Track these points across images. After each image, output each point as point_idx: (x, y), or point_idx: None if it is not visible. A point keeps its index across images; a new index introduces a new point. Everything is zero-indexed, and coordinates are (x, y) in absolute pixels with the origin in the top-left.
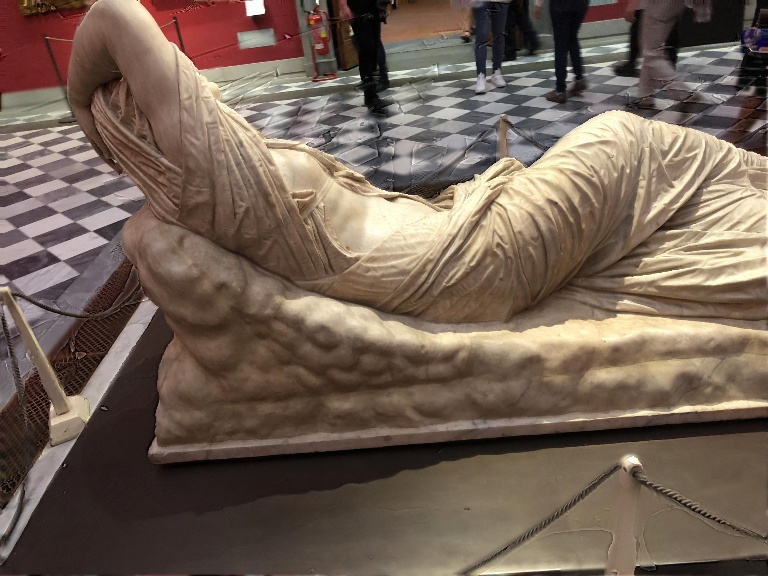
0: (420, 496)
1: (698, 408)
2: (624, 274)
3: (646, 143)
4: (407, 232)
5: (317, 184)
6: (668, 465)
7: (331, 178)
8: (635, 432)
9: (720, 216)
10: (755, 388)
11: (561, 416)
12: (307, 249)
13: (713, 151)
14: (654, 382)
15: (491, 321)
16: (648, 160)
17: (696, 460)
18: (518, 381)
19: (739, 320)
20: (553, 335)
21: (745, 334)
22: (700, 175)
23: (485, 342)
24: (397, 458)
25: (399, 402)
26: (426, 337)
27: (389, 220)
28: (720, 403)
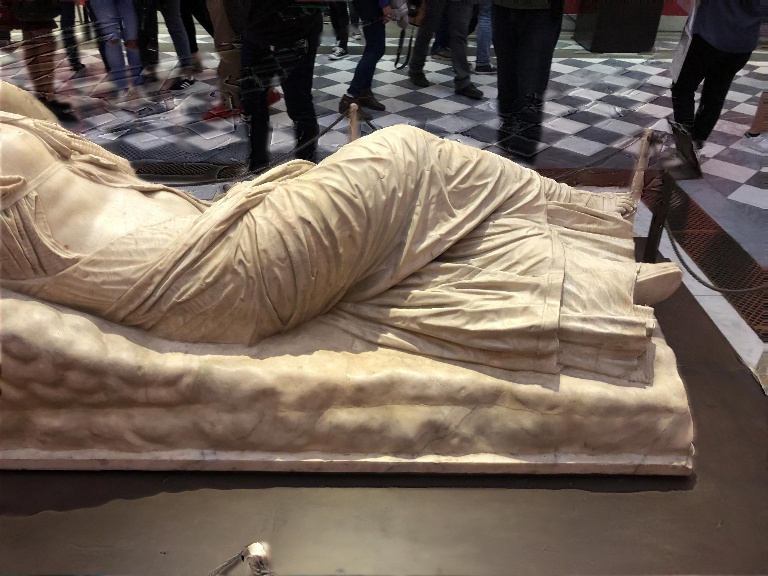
0: (120, 532)
1: (442, 458)
2: (393, 305)
3: (427, 166)
4: (141, 235)
5: (31, 169)
6: (395, 518)
7: (61, 163)
8: (376, 477)
9: (500, 253)
10: (503, 442)
11: (298, 454)
12: (6, 245)
13: (510, 181)
14: (398, 427)
15: (234, 343)
16: (426, 185)
17: (428, 515)
18: (249, 414)
19: (498, 368)
20: (295, 367)
21: (498, 385)
22: (488, 206)
23: (215, 368)
24: (115, 484)
25: (116, 424)
26: (148, 357)
27: (128, 218)
28: (466, 454)
